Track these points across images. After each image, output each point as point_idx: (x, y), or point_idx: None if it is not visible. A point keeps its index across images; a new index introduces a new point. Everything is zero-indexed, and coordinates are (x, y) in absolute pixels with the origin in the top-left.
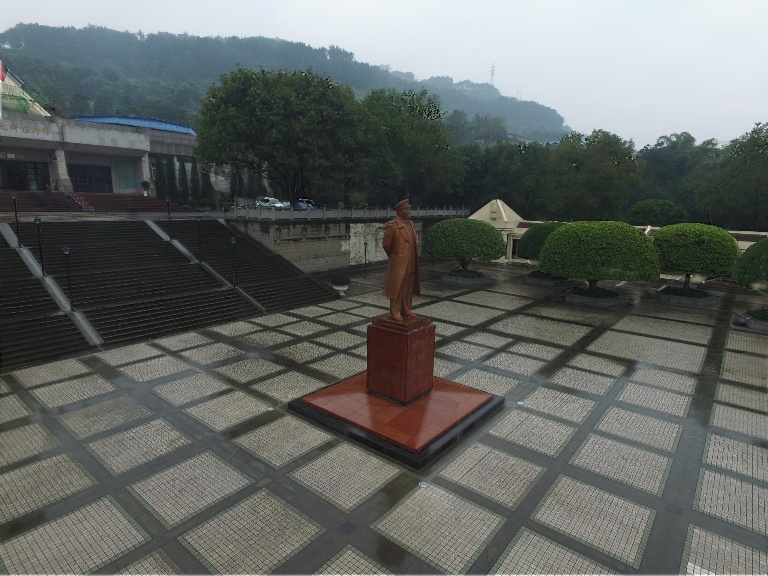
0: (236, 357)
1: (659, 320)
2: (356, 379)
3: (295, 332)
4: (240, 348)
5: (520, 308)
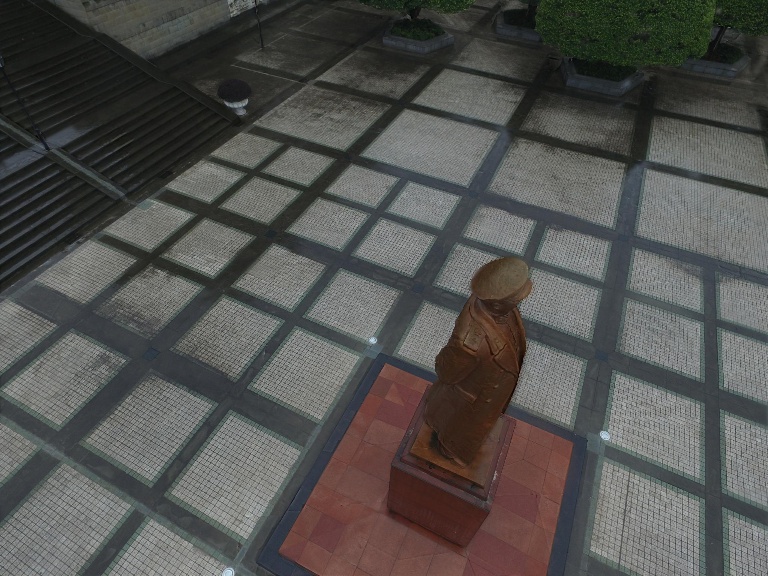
0: (114, 383)
1: (696, 126)
2: (352, 447)
3: (197, 265)
4: (113, 346)
5: (514, 117)
